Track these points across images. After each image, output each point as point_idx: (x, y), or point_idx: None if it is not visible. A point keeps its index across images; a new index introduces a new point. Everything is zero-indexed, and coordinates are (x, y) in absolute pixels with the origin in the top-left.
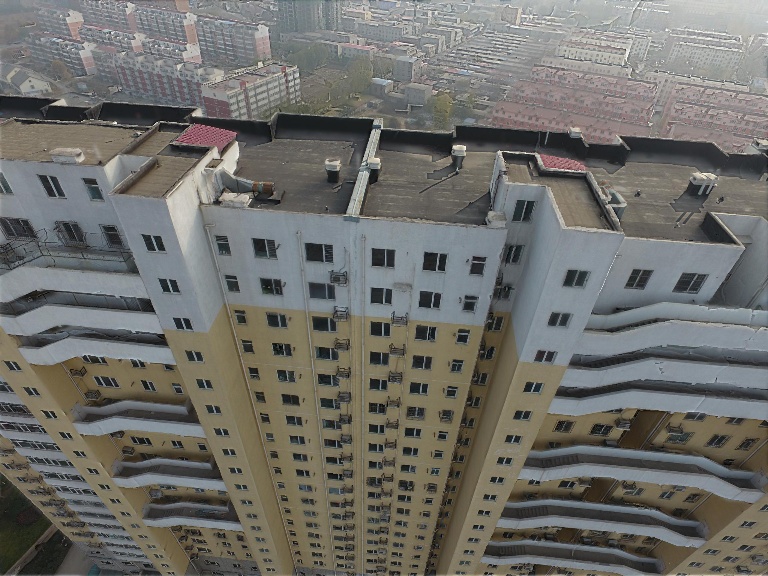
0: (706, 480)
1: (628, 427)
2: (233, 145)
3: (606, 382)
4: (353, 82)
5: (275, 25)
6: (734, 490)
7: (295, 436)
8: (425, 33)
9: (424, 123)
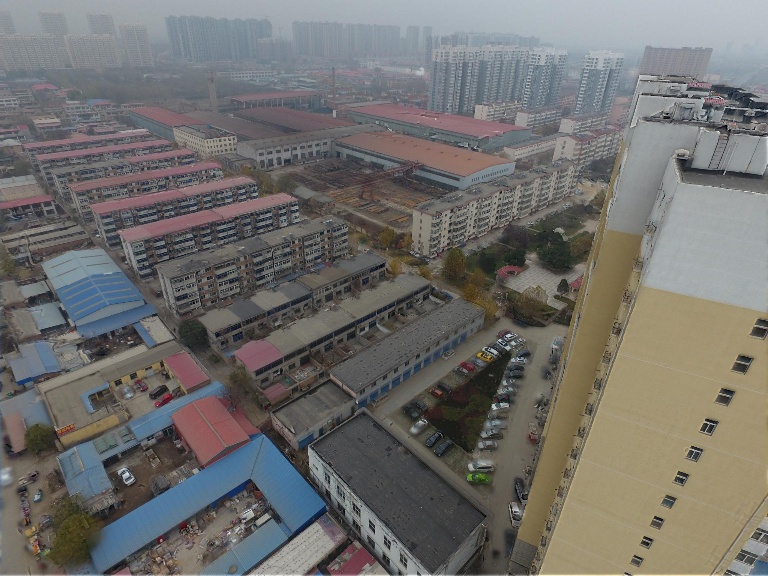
0: None
1: None
2: (704, 92)
3: None
4: None
5: None
6: None
7: None
8: None
9: None
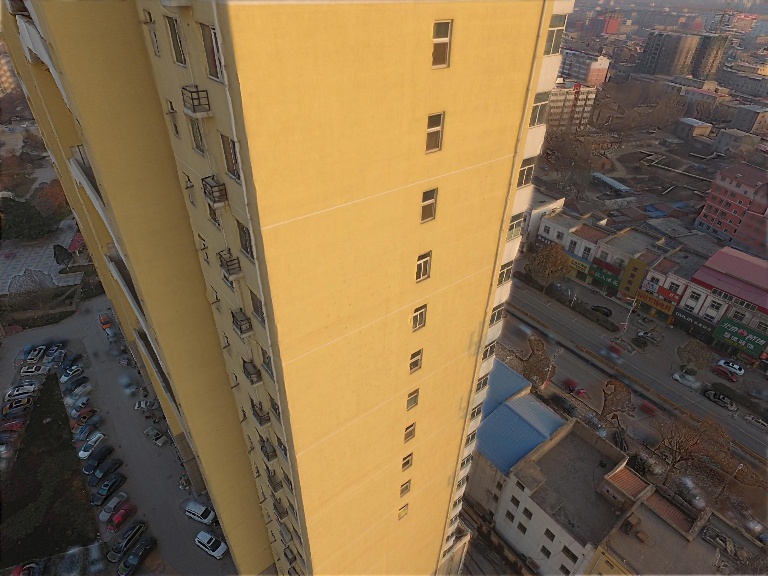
0: None
1: None
2: None
3: None
4: (652, 114)
5: (633, 66)
6: None
7: None
8: None
9: (714, 172)
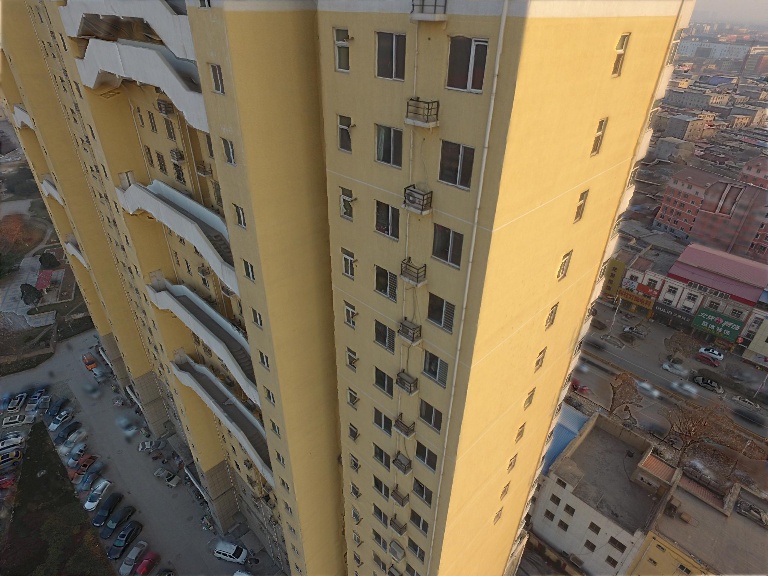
0: (192, 229)
1: (177, 159)
2: None
3: (75, 24)
4: None
5: None
6: (216, 259)
7: (91, 167)
8: (742, 104)
9: (659, 176)
